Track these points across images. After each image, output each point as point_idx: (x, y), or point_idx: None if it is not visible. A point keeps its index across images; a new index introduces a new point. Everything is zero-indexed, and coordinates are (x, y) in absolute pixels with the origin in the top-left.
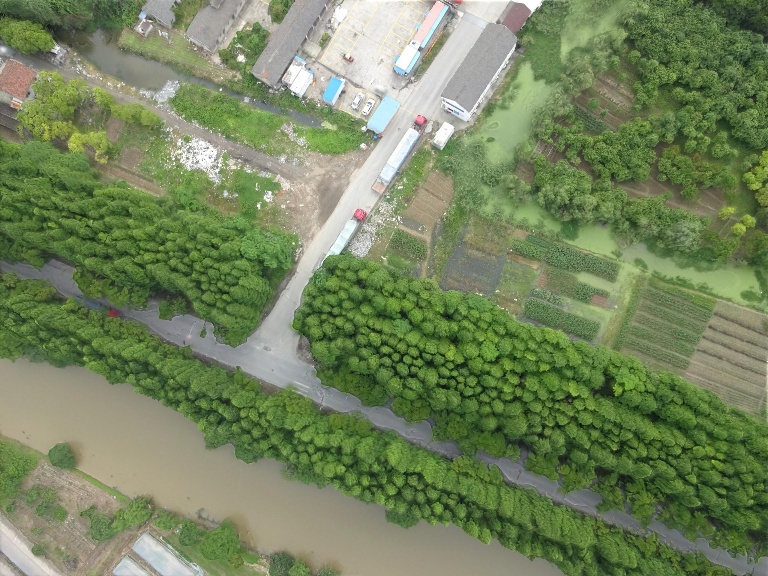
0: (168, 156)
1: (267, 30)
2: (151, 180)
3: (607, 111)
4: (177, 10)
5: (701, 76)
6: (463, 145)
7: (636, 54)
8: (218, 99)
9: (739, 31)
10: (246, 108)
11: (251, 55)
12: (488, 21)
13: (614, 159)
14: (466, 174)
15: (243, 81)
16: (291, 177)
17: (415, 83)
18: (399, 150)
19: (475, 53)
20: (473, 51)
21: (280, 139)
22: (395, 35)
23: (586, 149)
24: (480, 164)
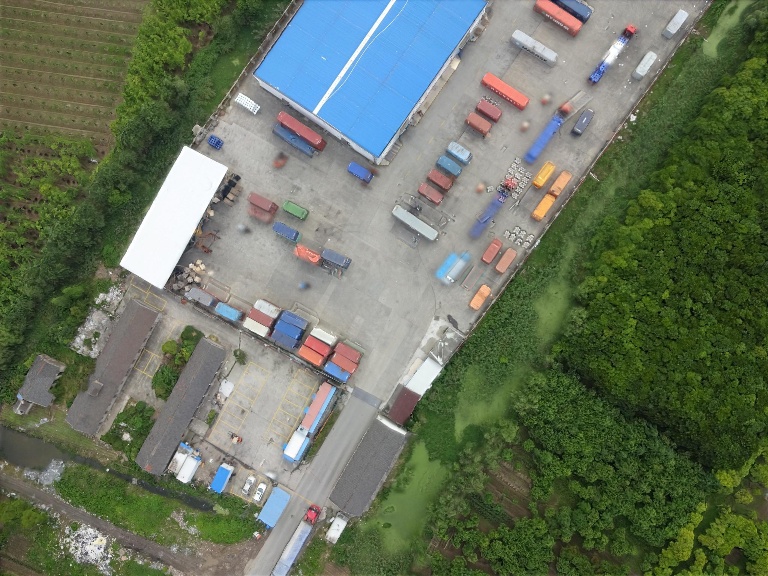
0: (56, 544)
1: (152, 407)
2: (40, 571)
3: (504, 496)
4: (56, 391)
5: (596, 472)
6: (358, 534)
7: (529, 446)
8: (104, 487)
9: (633, 421)
10: (134, 493)
11: (136, 435)
12: (379, 397)
13: (511, 561)
14: (362, 568)
15: (129, 464)
16: (184, 568)
17: (307, 465)
18: (291, 547)
19: (362, 454)
20: (360, 451)
21: (170, 527)
22: (284, 412)
23: (482, 549)
24: (376, 558)
